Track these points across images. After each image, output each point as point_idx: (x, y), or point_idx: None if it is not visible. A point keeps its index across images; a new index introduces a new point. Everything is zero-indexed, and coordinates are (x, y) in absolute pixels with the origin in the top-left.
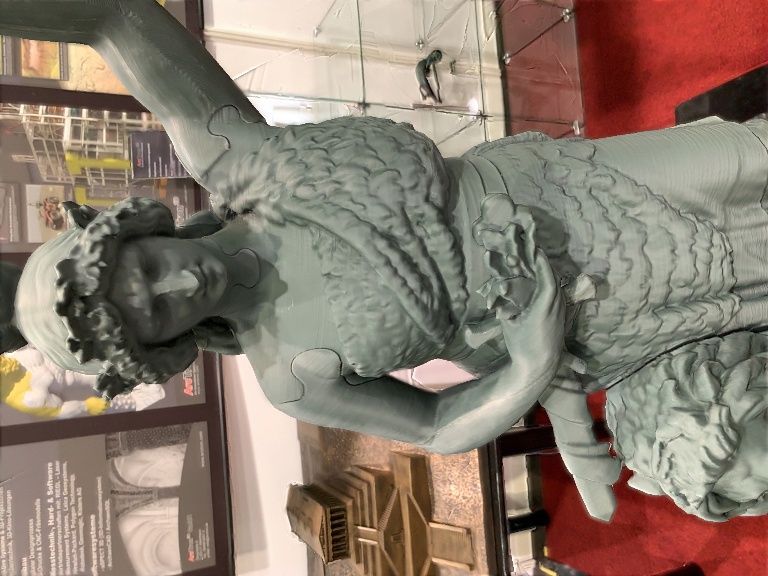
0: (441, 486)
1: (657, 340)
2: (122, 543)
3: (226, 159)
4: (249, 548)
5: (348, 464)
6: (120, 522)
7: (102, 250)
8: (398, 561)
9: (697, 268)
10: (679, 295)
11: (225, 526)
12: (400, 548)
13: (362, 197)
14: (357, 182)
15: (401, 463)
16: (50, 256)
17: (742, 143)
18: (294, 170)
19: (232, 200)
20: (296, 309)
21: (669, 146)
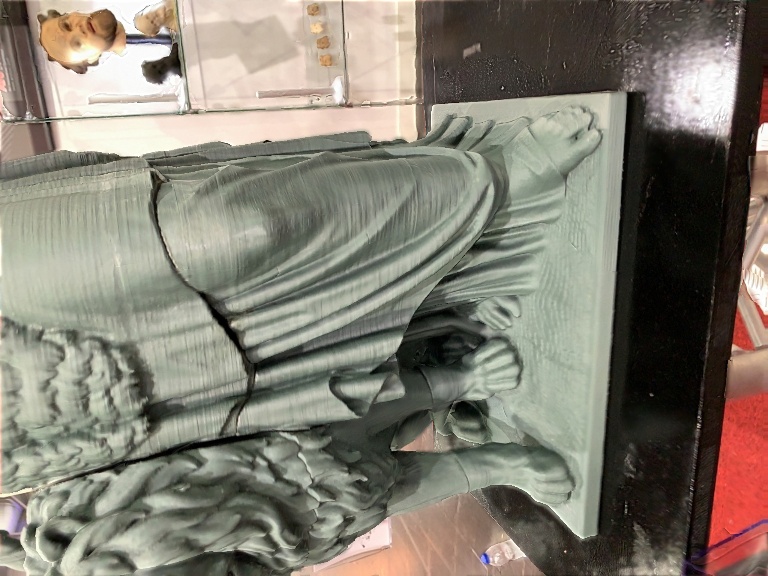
0: None
1: (22, 480)
2: None
3: None
4: None
5: None
6: None
7: None
8: None
9: (58, 406)
10: (42, 434)
11: None
12: None
13: None
14: None
15: None
16: None
17: (123, 243)
18: None
19: None
20: None
21: (13, 249)
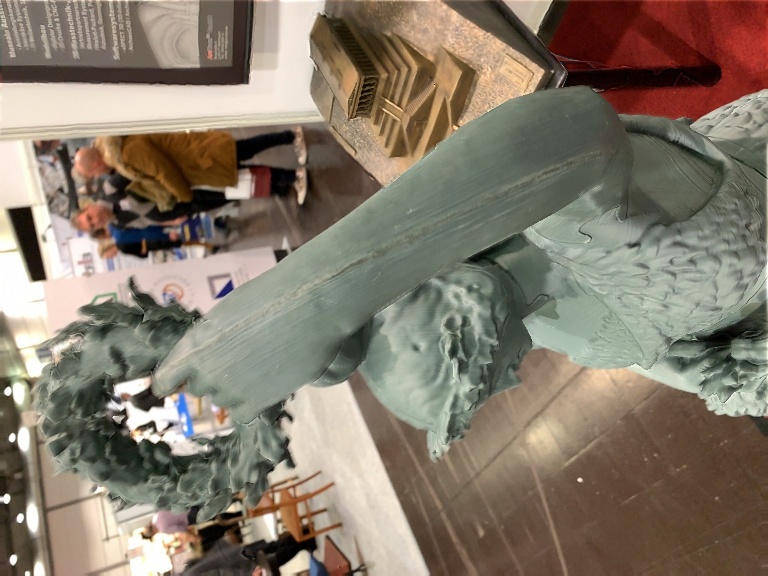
0: (479, 104)
1: None
2: (143, 32)
3: (576, 245)
4: (261, 50)
5: (390, 29)
6: (139, 10)
7: (475, 404)
8: (413, 140)
9: None
10: None
11: (244, 33)
12: (419, 131)
13: (676, 322)
14: (682, 314)
15: (450, 69)
16: (429, 394)
17: None
18: (636, 285)
19: (553, 253)
20: (555, 330)
21: None
